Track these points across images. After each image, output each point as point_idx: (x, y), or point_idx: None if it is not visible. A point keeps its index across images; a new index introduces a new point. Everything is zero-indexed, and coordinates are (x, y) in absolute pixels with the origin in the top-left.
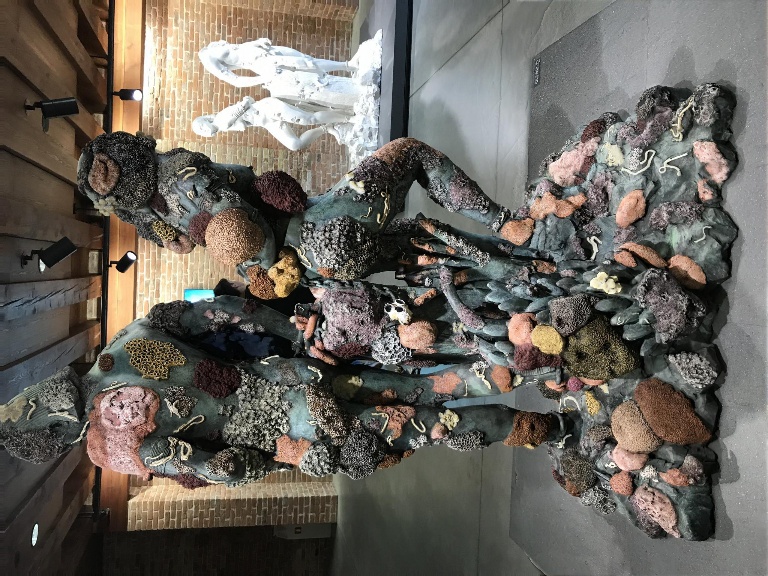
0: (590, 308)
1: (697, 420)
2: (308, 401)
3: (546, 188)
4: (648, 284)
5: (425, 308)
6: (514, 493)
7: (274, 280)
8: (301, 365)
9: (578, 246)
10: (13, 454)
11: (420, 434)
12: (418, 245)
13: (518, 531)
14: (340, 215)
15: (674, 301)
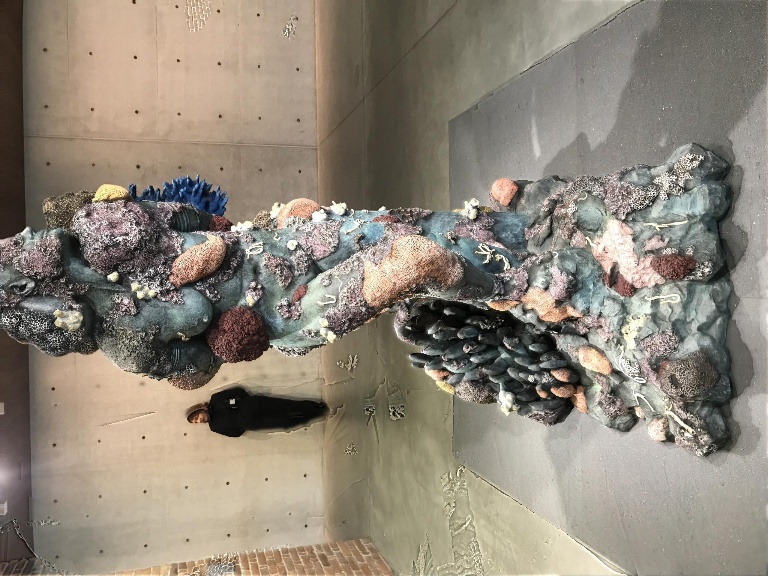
0: None
1: None
2: None
3: (555, 297)
4: None
5: None
6: (468, 114)
7: None
8: None
9: None
10: None
11: None
12: None
13: (455, 133)
14: (302, 346)
15: None
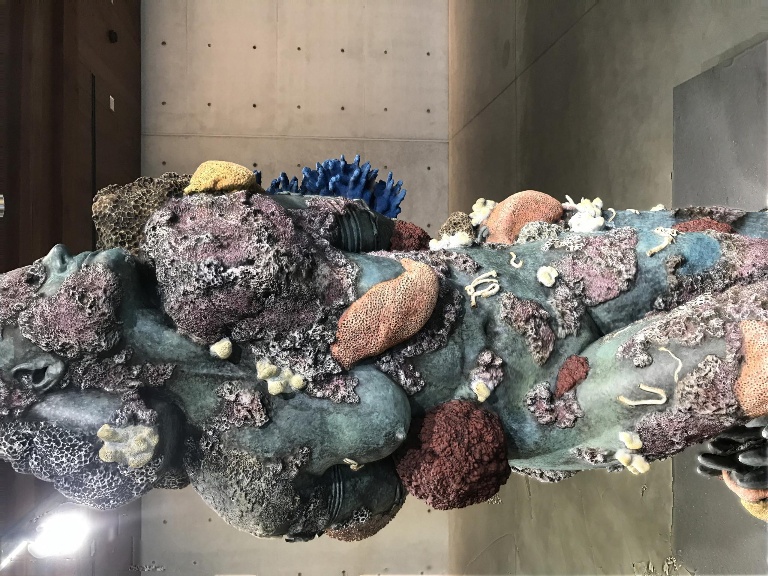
0: None
1: None
2: None
3: None
4: None
5: None
6: (711, 74)
7: None
8: None
9: None
10: None
11: None
12: None
13: (684, 104)
14: (563, 470)
15: None
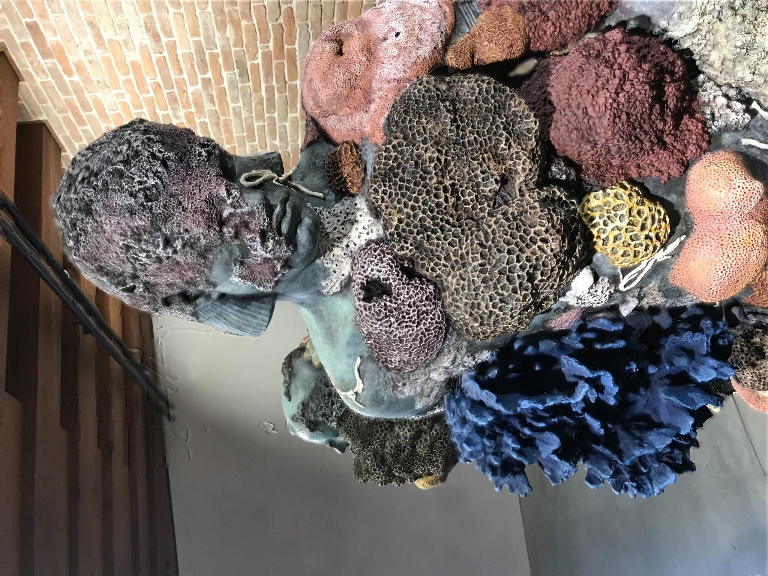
0: None
1: None
2: None
3: None
4: None
5: None
6: None
7: None
8: None
9: None
10: (82, 150)
11: None
12: None
13: None
14: None
15: None
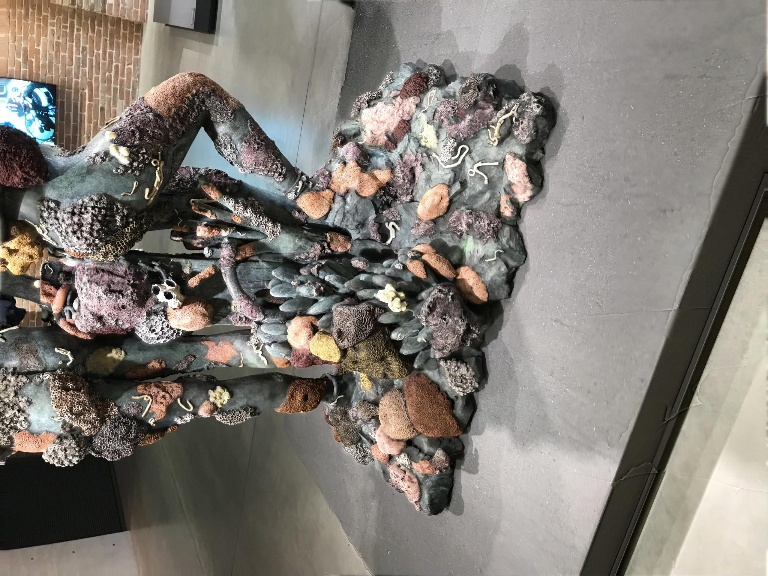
0: (373, 322)
1: (453, 421)
2: (52, 396)
3: (352, 156)
4: (433, 304)
5: (201, 284)
6: None
7: (6, 258)
8: (46, 347)
9: (375, 231)
10: None
11: (186, 413)
12: (198, 212)
13: (291, 427)
14: (94, 193)
15: (453, 325)
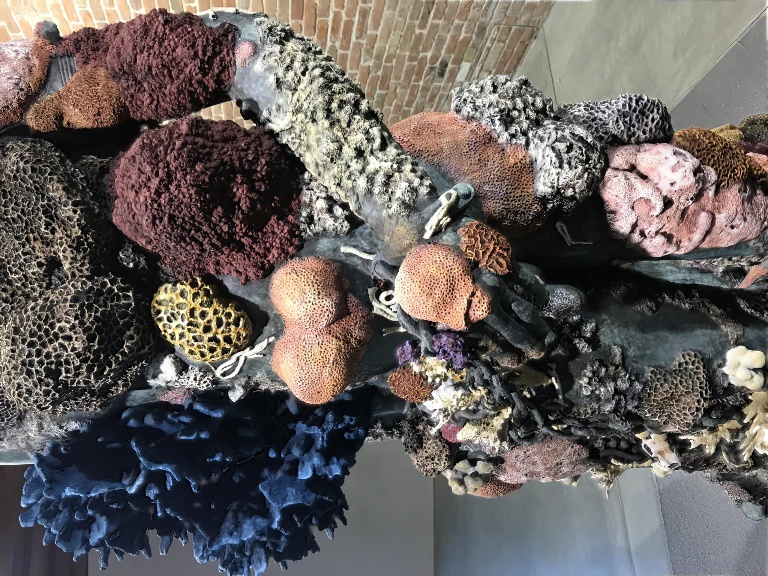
0: None
1: None
2: None
3: None
4: None
5: None
6: None
7: None
8: None
9: None
10: None
11: None
12: None
13: None
14: None
15: None
